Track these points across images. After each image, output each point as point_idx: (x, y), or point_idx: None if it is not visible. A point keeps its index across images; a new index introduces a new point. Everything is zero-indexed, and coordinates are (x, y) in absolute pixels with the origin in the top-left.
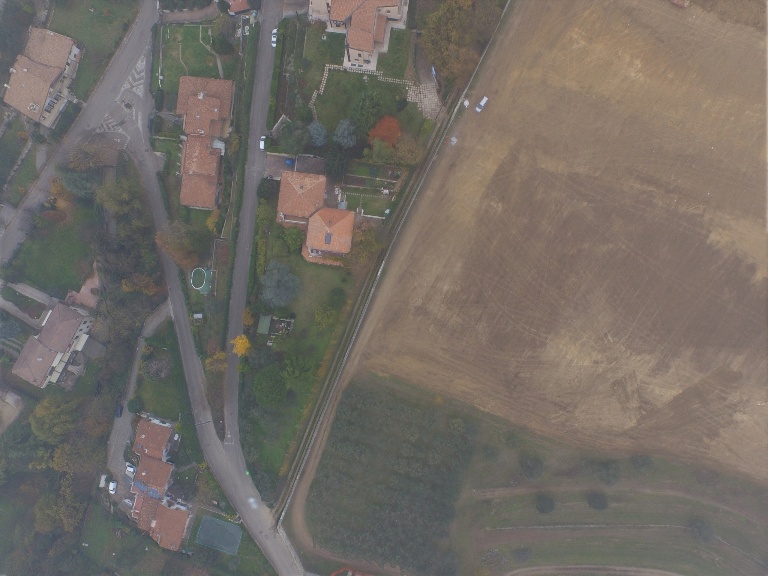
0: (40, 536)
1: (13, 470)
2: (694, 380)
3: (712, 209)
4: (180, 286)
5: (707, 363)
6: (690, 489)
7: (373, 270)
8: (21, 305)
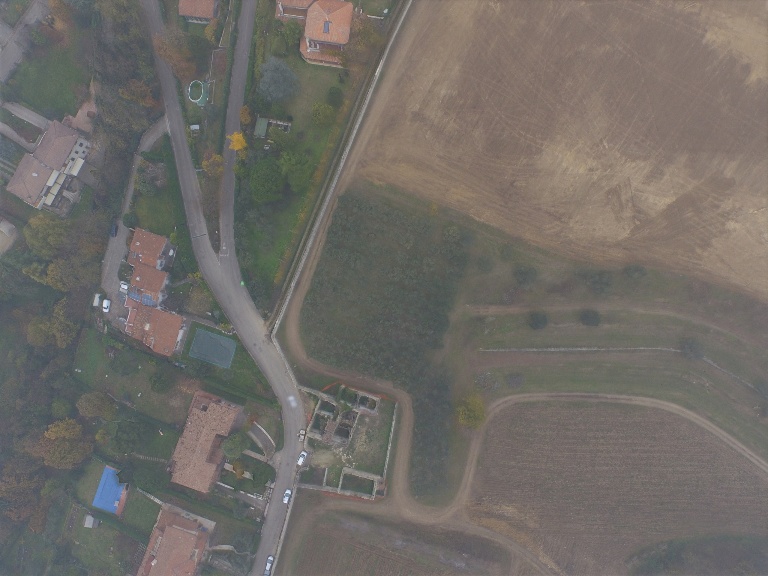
0: (33, 357)
1: (6, 296)
2: (688, 187)
3: (708, 7)
4: (177, 98)
5: (701, 169)
6: (682, 308)
7: (371, 74)
8: (17, 124)
